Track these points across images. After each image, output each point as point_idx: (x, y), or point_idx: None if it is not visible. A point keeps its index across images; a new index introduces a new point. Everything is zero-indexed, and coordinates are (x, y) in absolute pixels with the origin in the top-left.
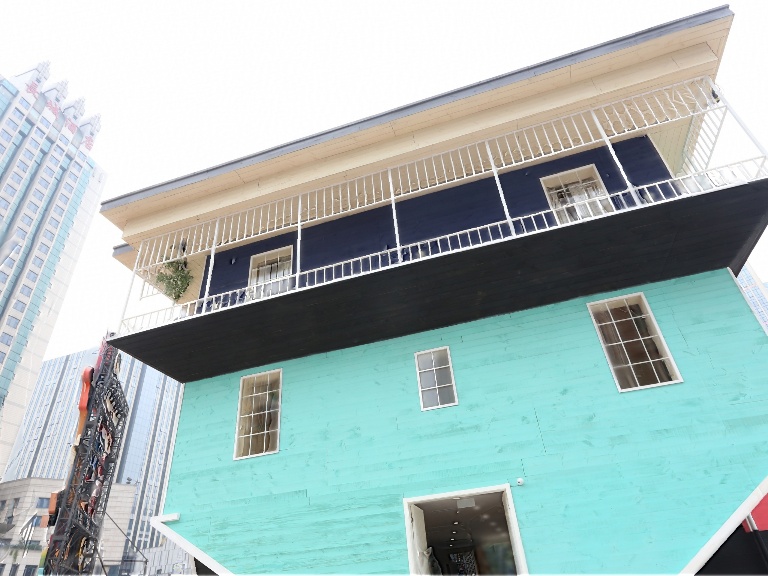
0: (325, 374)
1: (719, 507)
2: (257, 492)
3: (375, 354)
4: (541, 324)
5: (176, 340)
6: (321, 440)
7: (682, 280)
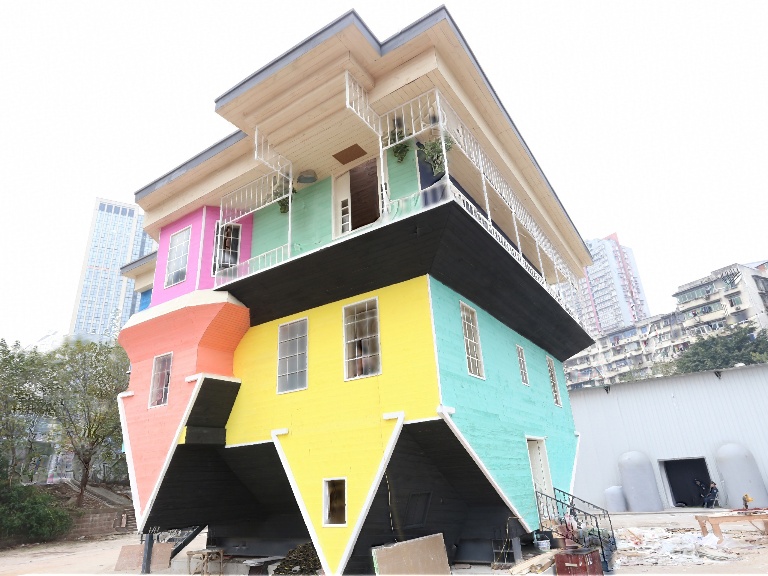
0: (492, 332)
1: (571, 462)
2: (482, 407)
3: (505, 333)
4: (539, 356)
5: (472, 243)
6: (498, 381)
7: (557, 361)
